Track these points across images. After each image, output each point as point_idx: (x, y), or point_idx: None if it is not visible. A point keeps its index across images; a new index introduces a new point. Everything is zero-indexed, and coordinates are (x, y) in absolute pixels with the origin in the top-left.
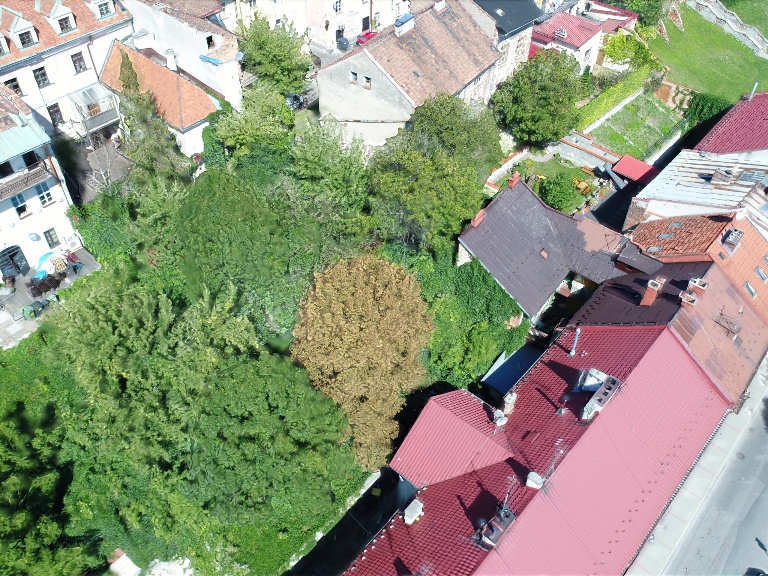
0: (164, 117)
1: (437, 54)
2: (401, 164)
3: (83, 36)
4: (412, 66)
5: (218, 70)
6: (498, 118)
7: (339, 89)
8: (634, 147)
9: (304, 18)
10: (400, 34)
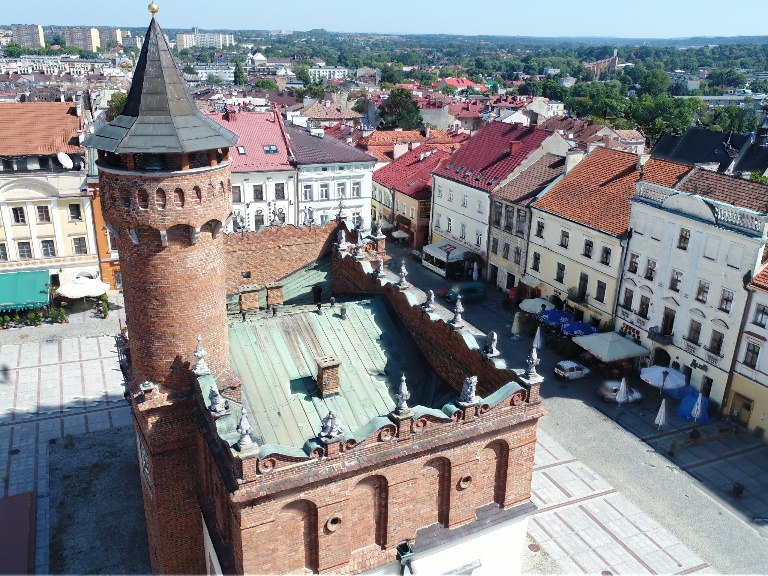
0: None
1: None
2: None
3: None
4: None
5: None
6: None
7: None
8: None
9: None
10: None
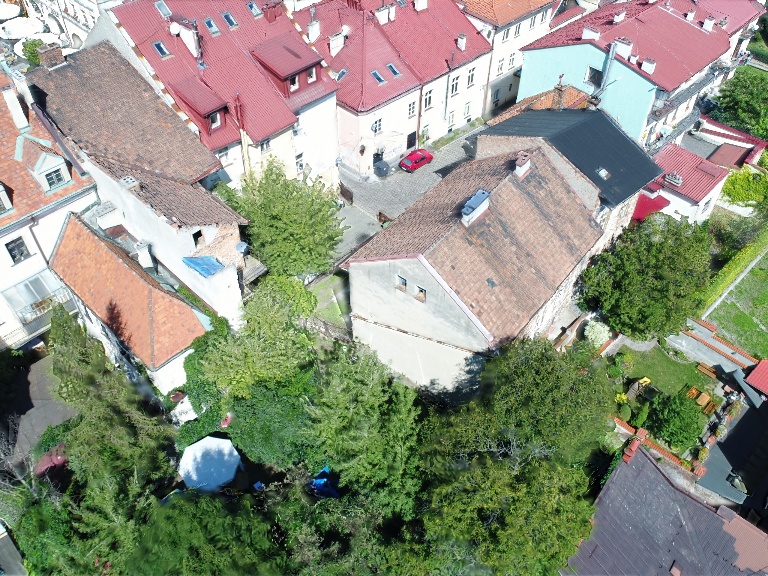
0: (129, 344)
1: (519, 245)
2: None
3: (22, 219)
4: (485, 270)
5: (207, 282)
6: (586, 290)
7: (379, 290)
8: (767, 335)
9: (333, 147)
10: (469, 222)
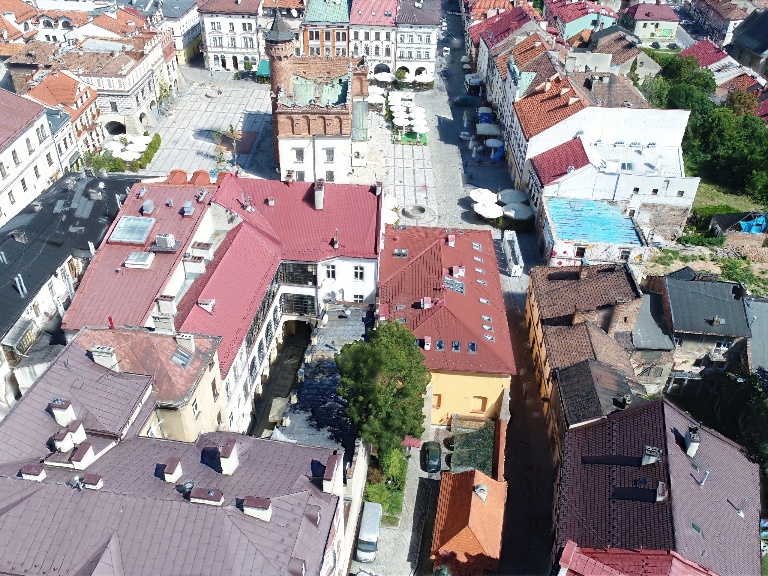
0: None
1: None
2: (699, 74)
3: None
4: None
5: (619, 68)
6: None
7: (627, 71)
8: None
9: None
10: None
